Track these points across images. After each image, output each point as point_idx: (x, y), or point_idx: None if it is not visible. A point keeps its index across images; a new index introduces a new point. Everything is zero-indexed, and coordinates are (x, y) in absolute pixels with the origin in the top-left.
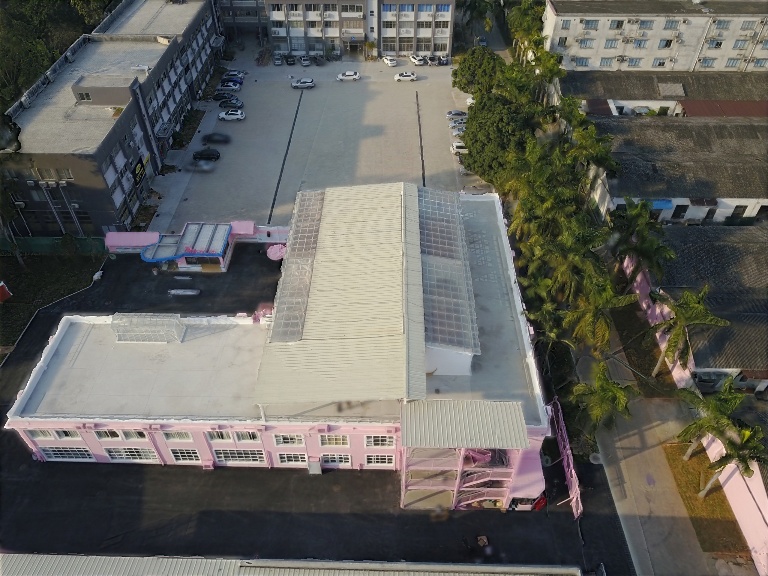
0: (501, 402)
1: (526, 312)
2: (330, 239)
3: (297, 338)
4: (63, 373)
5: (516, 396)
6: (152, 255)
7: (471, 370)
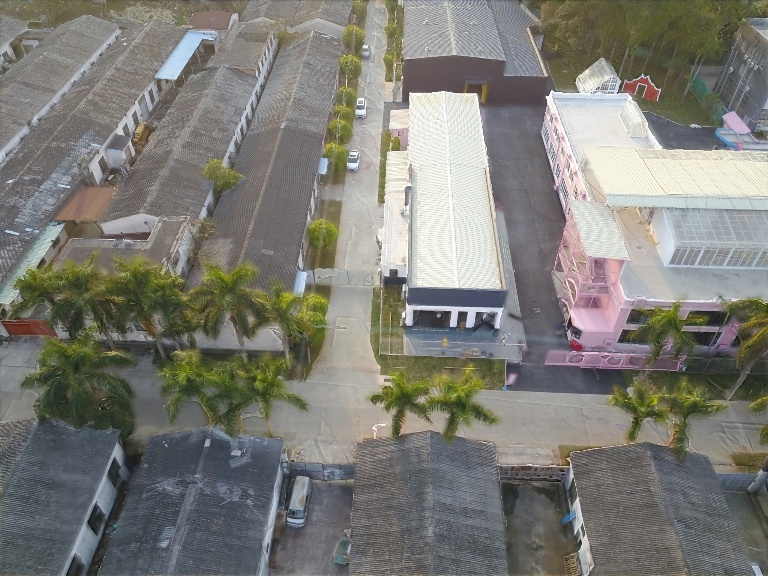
0: (626, 249)
1: (764, 303)
2: (767, 166)
3: (644, 158)
4: (587, 104)
5: (654, 290)
6: (723, 133)
7: (671, 267)
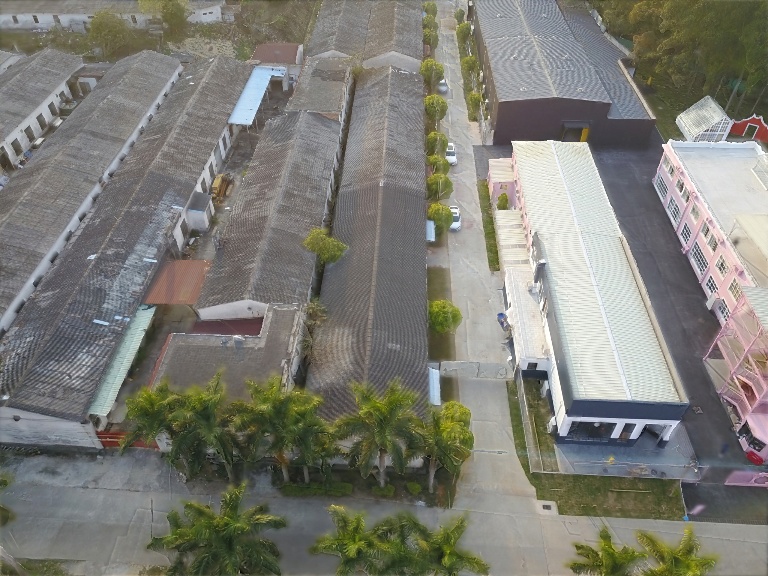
0: None
1: None
2: None
3: None
4: (712, 154)
5: None
6: None
7: None
